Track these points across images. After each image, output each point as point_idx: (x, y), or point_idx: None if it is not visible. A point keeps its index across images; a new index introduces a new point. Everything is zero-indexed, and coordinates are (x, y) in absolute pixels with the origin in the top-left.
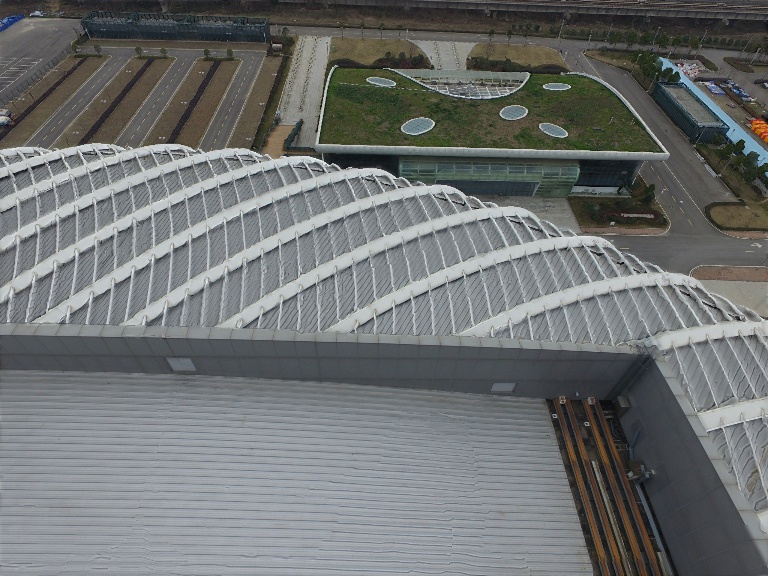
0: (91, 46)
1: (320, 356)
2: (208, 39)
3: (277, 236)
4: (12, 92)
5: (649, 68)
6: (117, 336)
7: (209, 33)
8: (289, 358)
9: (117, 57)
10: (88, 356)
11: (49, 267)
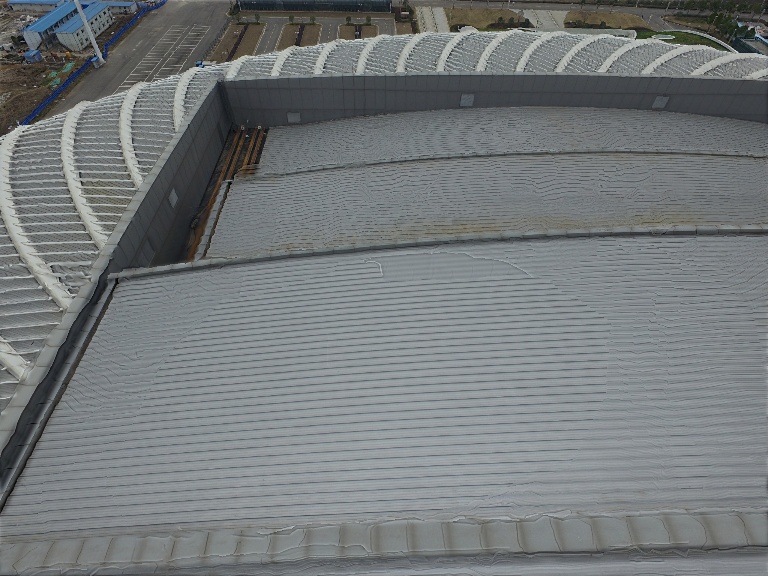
0: (245, 16)
1: (738, 93)
2: (340, 10)
3: (666, 55)
4: (207, 50)
5: (727, 26)
6: (650, 76)
7: (342, 4)
8: (721, 95)
9: (272, 24)
10: (621, 94)
11: (566, 63)
